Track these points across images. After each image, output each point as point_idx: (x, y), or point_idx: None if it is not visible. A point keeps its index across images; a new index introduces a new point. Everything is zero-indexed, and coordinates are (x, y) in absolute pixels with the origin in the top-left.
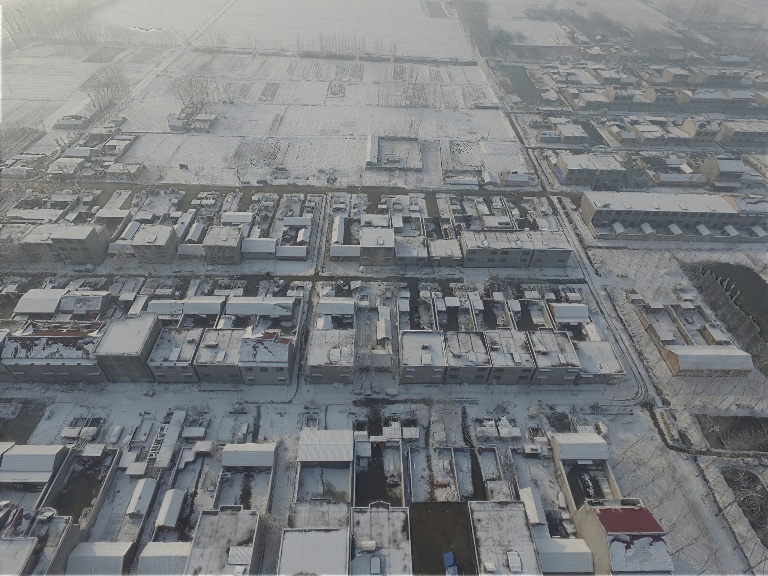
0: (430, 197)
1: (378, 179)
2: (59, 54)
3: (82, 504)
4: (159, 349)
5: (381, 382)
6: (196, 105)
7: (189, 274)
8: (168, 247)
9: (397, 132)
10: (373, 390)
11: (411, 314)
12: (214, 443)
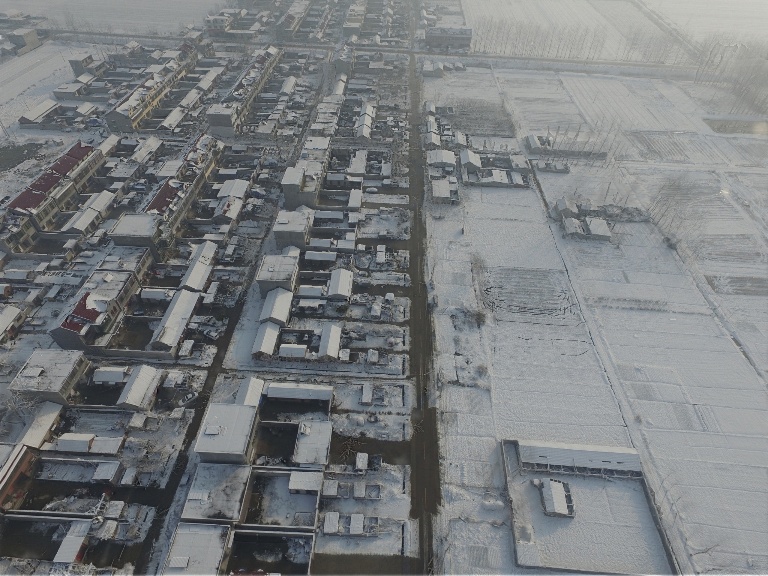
0: (404, 569)
1: (470, 464)
2: (707, 102)
3: (43, 252)
4: (125, 249)
5: (12, 437)
6: (634, 214)
7: (258, 264)
8: (282, 237)
9: (702, 525)
10: (4, 427)
11: (95, 485)
12: (28, 302)
